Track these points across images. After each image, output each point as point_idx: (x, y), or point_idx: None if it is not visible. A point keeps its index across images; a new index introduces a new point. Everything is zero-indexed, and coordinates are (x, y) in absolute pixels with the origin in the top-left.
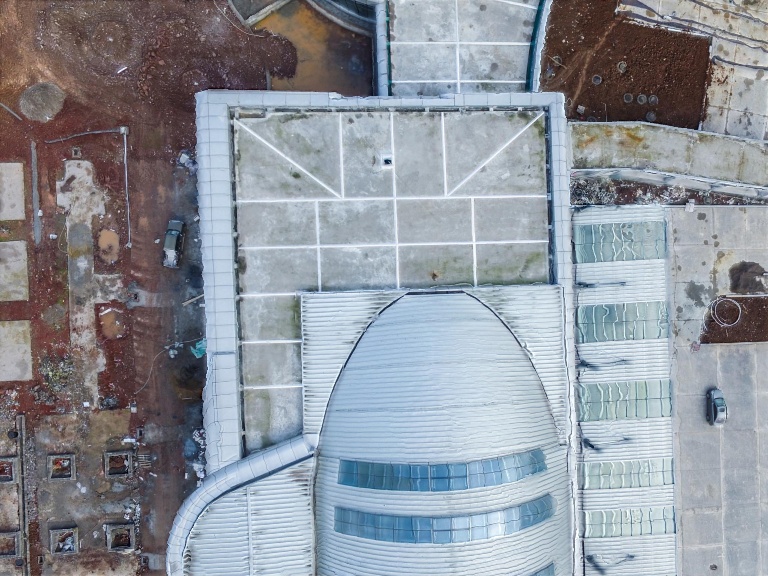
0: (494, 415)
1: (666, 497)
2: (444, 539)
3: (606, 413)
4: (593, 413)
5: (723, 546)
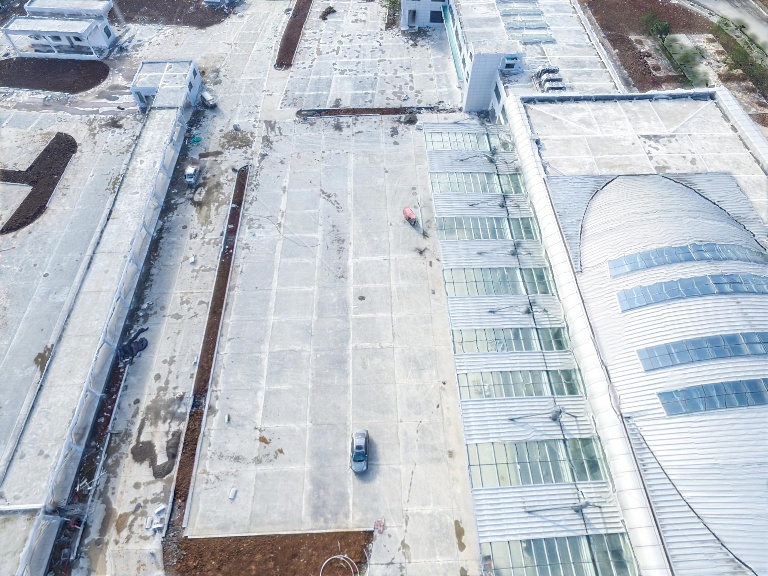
0: (741, 452)
1: (463, 362)
2: (765, 336)
3: (539, 448)
4: (553, 448)
5: (352, 315)
